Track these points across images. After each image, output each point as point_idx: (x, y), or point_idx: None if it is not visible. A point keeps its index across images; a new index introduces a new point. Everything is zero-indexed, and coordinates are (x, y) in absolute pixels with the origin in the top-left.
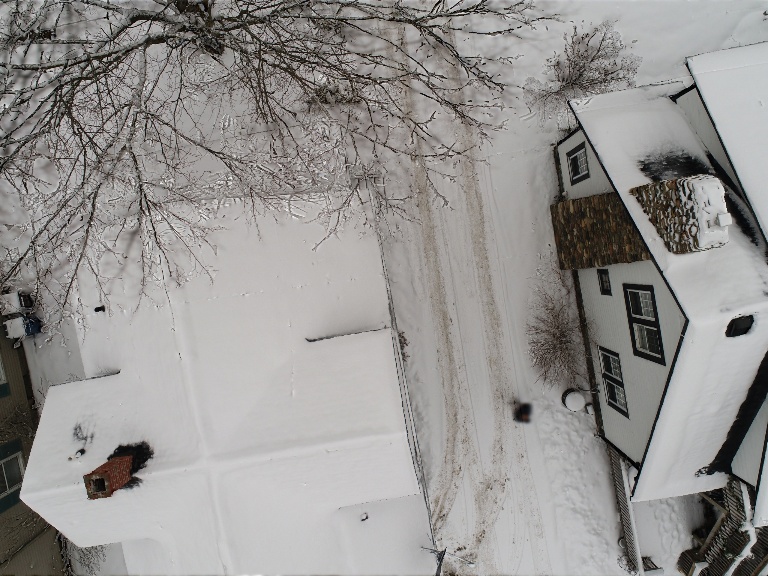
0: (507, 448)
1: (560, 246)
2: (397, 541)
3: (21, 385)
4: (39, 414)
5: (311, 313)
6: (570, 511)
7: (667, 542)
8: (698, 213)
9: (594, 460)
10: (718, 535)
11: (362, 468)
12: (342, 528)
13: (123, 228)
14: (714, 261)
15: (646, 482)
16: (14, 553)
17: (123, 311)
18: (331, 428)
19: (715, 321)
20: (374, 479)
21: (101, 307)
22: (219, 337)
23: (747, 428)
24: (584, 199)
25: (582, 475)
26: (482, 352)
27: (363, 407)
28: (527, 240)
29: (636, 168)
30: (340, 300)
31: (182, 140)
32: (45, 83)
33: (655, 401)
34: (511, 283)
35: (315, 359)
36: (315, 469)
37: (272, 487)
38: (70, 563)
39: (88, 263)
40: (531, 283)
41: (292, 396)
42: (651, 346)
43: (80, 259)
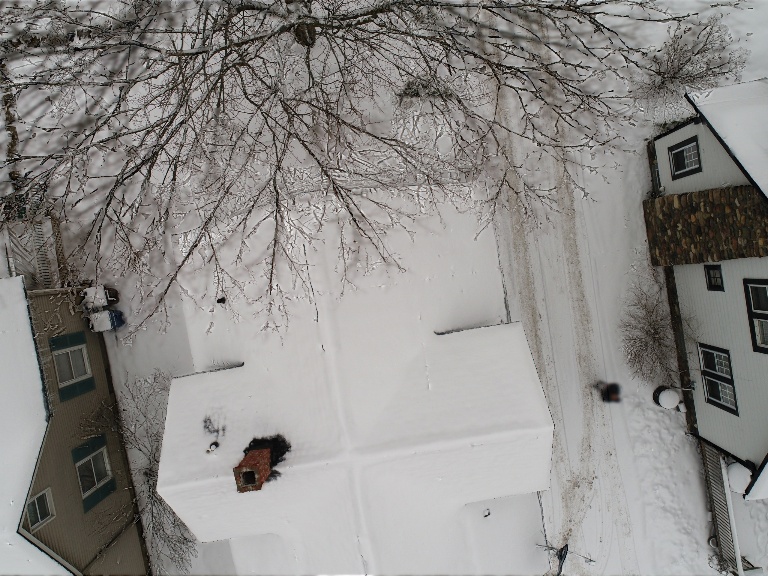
0: (595, 446)
1: (654, 242)
2: (516, 538)
3: (104, 379)
4: (120, 409)
5: (438, 306)
6: (660, 510)
7: (763, 542)
8: None
9: (684, 458)
10: None
11: (501, 463)
12: (468, 524)
13: (324, 213)
14: None
15: (767, 480)
16: None
17: None
18: (475, 422)
19: None
20: (510, 474)
21: (222, 299)
22: (359, 329)
23: None
24: (698, 193)
25: (672, 473)
26: (571, 349)
27: (505, 401)
28: (619, 236)
29: None
30: (463, 293)
31: (344, 127)
32: (158, 72)
33: None
34: (603, 279)
35: (448, 352)
36: (454, 463)
37: (408, 482)
38: (149, 559)
39: (282, 249)
40: (623, 279)
41: (429, 389)
42: None
43: (275, 245)
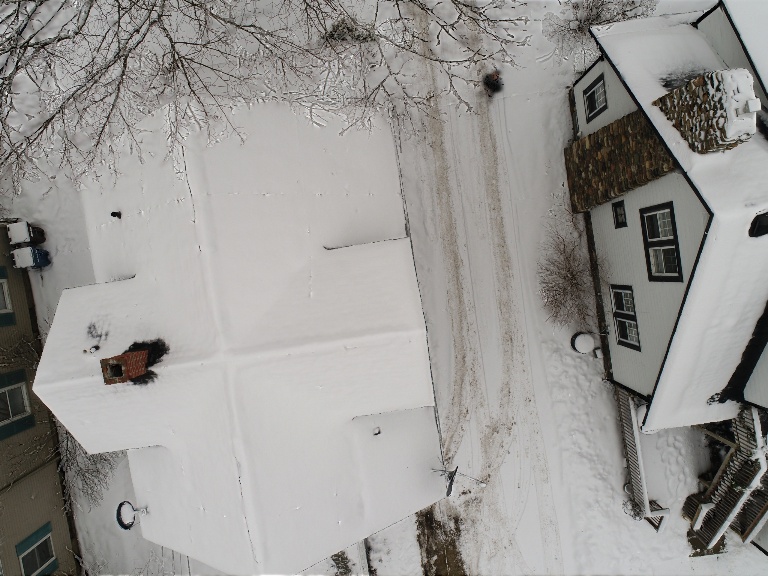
0: (515, 392)
1: (573, 188)
2: (408, 459)
3: (27, 317)
4: None
5: (330, 222)
6: (576, 455)
7: (673, 485)
8: (726, 103)
9: (601, 405)
10: (726, 472)
11: (379, 370)
12: (355, 440)
13: (157, 75)
14: (738, 163)
15: (659, 406)
16: (16, 479)
17: (141, 212)
18: (350, 326)
19: (740, 215)
20: (390, 384)
21: (117, 213)
22: (239, 233)
23: (762, 348)
24: (602, 129)
25: (589, 420)
26: (492, 294)
27: (382, 307)
28: (540, 182)
29: (658, 84)
30: (358, 213)
31: (212, 19)
32: None
33: (671, 321)
34: (523, 225)
35: (333, 264)
36: (332, 369)
37: (288, 388)
38: None
39: (120, 114)
40: None
41: (310, 297)
42: (668, 267)
43: (112, 109)
